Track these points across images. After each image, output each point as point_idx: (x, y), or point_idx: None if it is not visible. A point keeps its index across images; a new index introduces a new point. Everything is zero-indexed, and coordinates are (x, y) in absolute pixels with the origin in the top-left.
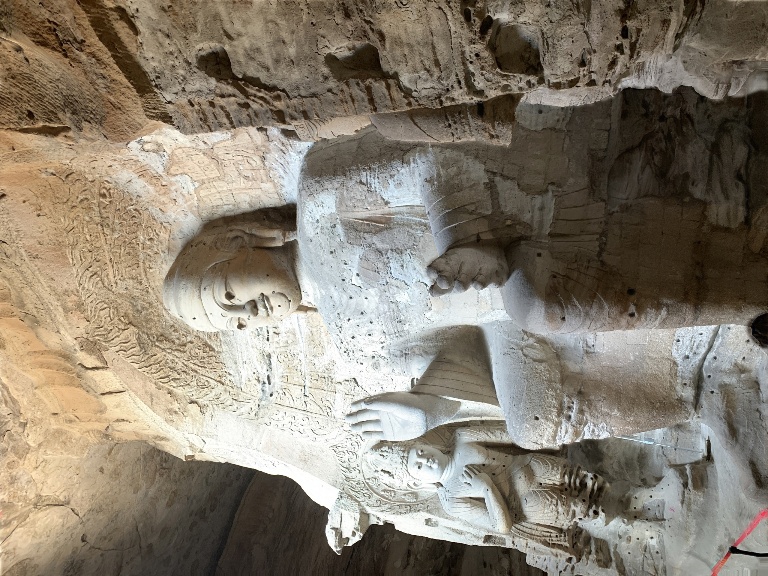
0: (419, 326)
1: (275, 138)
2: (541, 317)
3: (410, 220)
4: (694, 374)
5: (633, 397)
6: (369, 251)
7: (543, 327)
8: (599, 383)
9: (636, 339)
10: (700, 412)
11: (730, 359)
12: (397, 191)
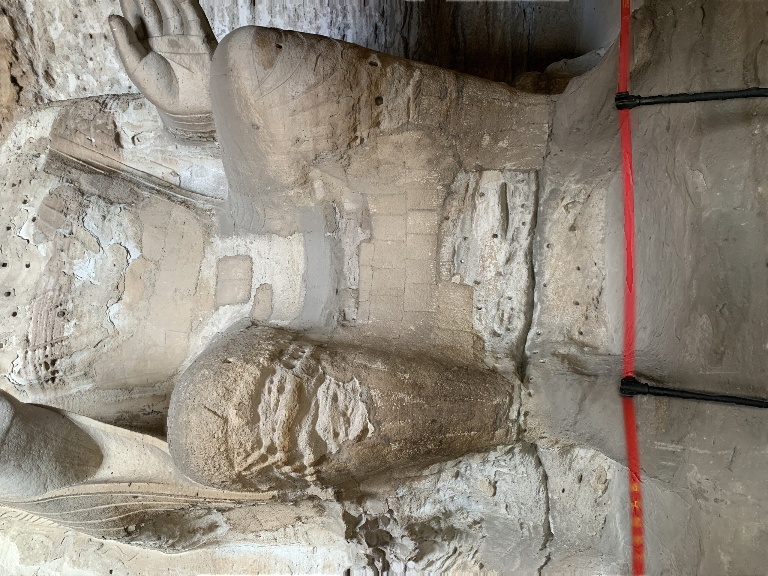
0: (91, 337)
1: (26, 104)
2: (249, 38)
3: (141, 183)
4: (512, 352)
5: (411, 357)
6: (67, 187)
7: (250, 56)
8: (356, 346)
9: (417, 303)
10: (530, 386)
11: (560, 328)
12: (135, 115)
